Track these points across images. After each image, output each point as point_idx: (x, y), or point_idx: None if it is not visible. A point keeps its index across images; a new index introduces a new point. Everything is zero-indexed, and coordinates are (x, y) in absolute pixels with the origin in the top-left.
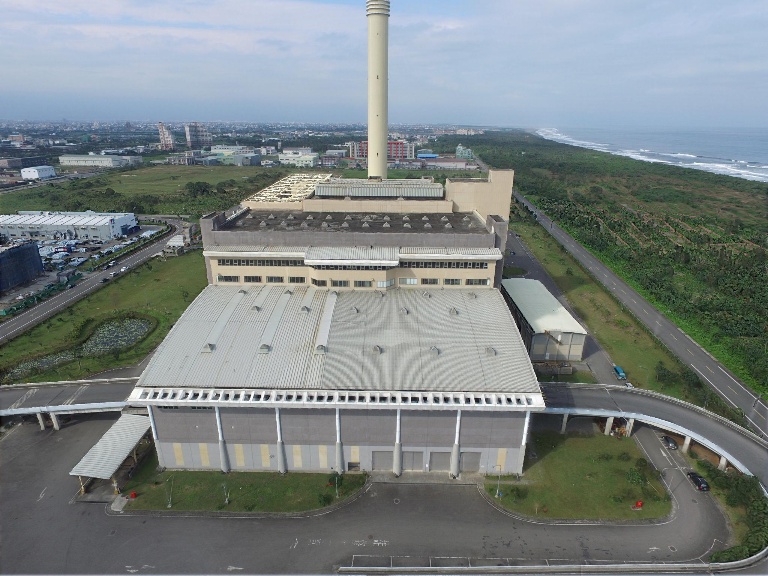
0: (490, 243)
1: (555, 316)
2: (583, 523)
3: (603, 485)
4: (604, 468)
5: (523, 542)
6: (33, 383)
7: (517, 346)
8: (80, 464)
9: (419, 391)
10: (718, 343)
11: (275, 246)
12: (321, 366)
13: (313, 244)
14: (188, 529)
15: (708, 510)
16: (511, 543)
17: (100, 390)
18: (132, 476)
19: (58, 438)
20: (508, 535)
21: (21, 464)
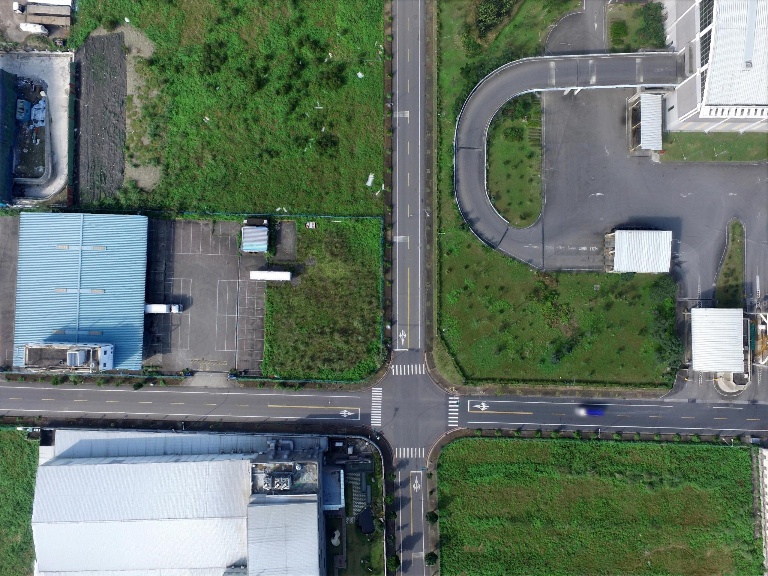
0: None
1: None
2: None
3: None
4: None
5: None
6: (549, 56)
7: None
8: (643, 141)
9: None
10: None
11: None
12: None
13: None
14: (701, 173)
15: None
16: None
17: (609, 66)
18: None
19: (582, 103)
20: None
21: (576, 127)
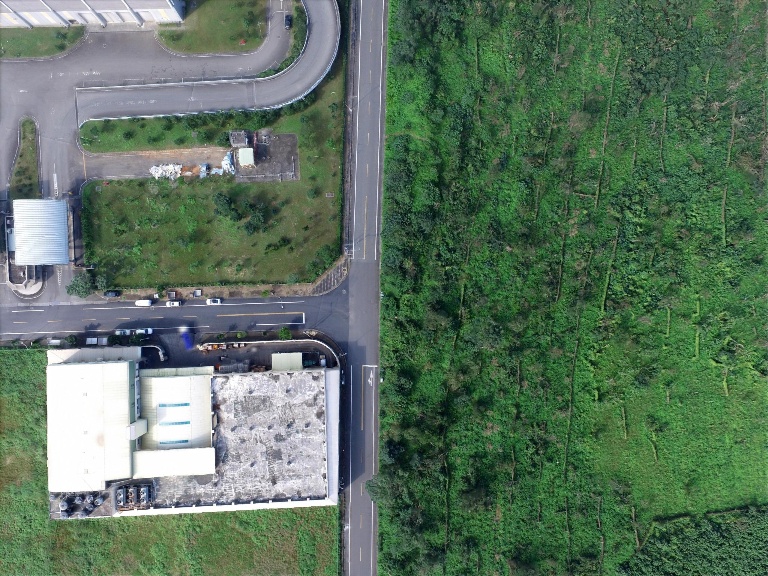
0: None
1: None
2: (209, 55)
3: (229, 28)
4: (235, 14)
5: (173, 69)
6: None
7: None
8: None
9: None
10: None
11: None
12: None
13: None
14: None
15: (283, 43)
16: (166, 70)
17: None
18: None
19: None
20: (166, 65)
21: None
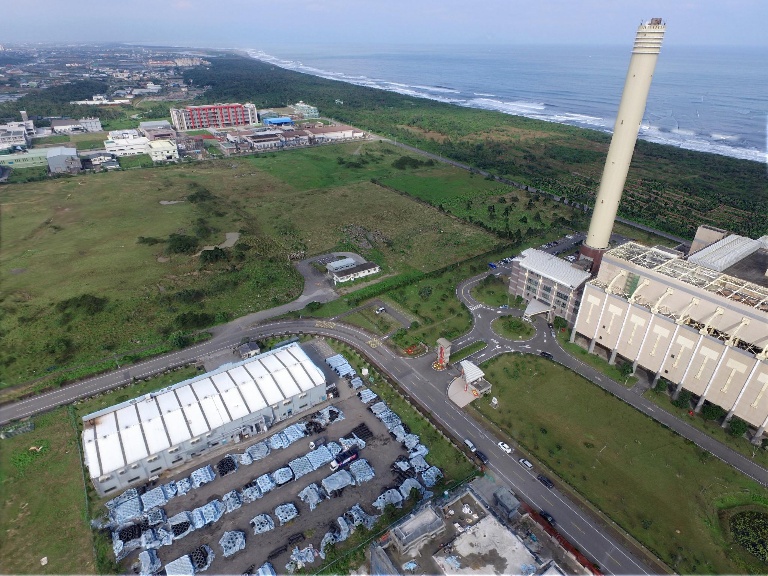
0: None
1: None
2: None
3: None
4: None
5: None
6: None
7: None
8: None
9: None
10: None
11: None
12: None
13: None
14: None
15: None
16: None
17: None
18: None
19: None
20: None
21: None
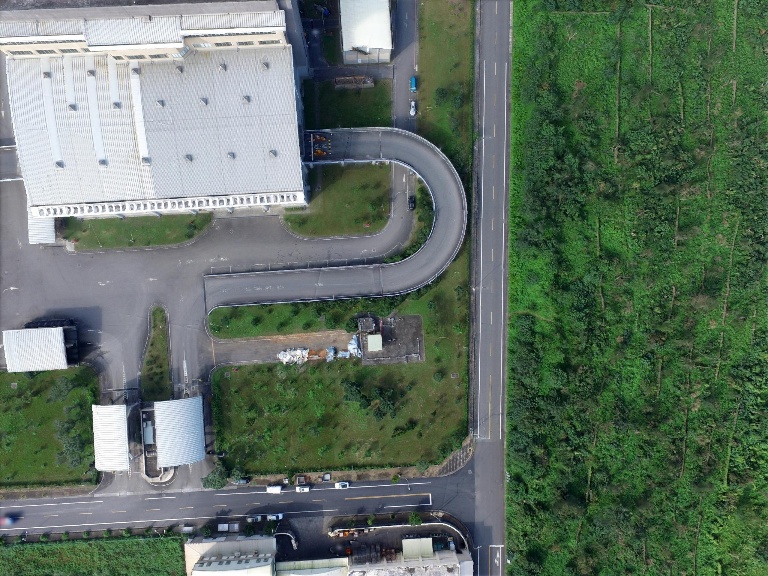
0: (273, 7)
1: (370, 17)
2: (334, 238)
3: (353, 211)
4: (359, 197)
5: (298, 253)
6: None
7: (293, 145)
8: (30, 236)
9: (223, 196)
10: (530, 20)
11: (46, 21)
12: (151, 178)
13: (86, 17)
14: (119, 260)
15: (406, 224)
16: (292, 254)
17: None
18: (65, 226)
19: None
20: (291, 249)
21: None
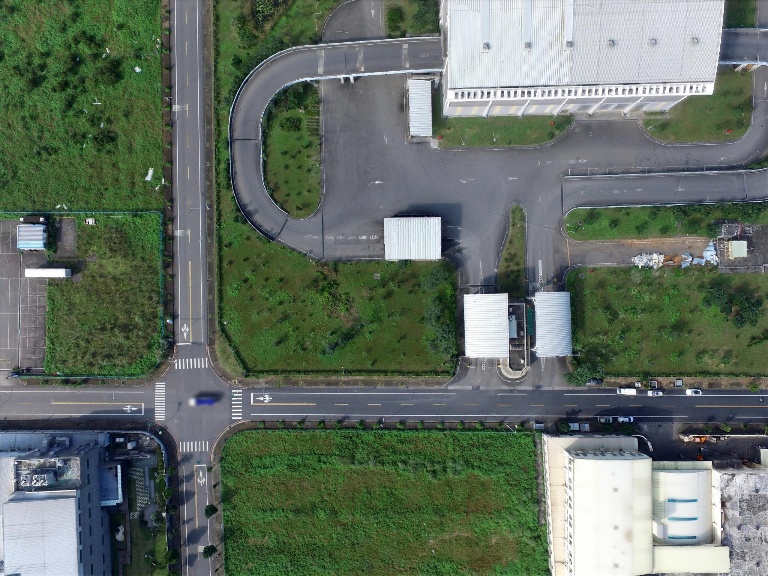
0: None
1: None
2: (692, 144)
3: (714, 118)
4: (721, 103)
5: (657, 158)
6: (316, 45)
7: (716, 32)
8: (411, 128)
9: (635, 84)
10: None
11: None
12: (570, 63)
13: None
14: (480, 158)
15: (766, 132)
16: (650, 159)
17: (375, 53)
18: None
19: (359, 91)
20: (650, 154)
21: (354, 116)
